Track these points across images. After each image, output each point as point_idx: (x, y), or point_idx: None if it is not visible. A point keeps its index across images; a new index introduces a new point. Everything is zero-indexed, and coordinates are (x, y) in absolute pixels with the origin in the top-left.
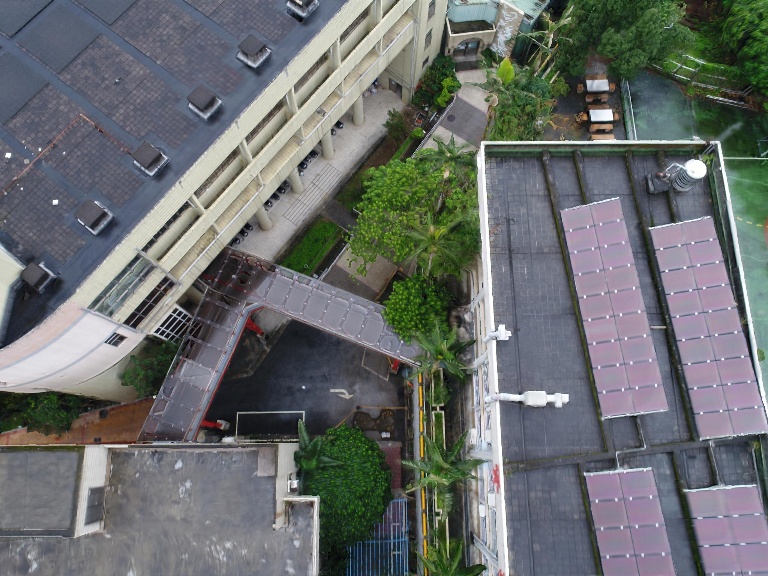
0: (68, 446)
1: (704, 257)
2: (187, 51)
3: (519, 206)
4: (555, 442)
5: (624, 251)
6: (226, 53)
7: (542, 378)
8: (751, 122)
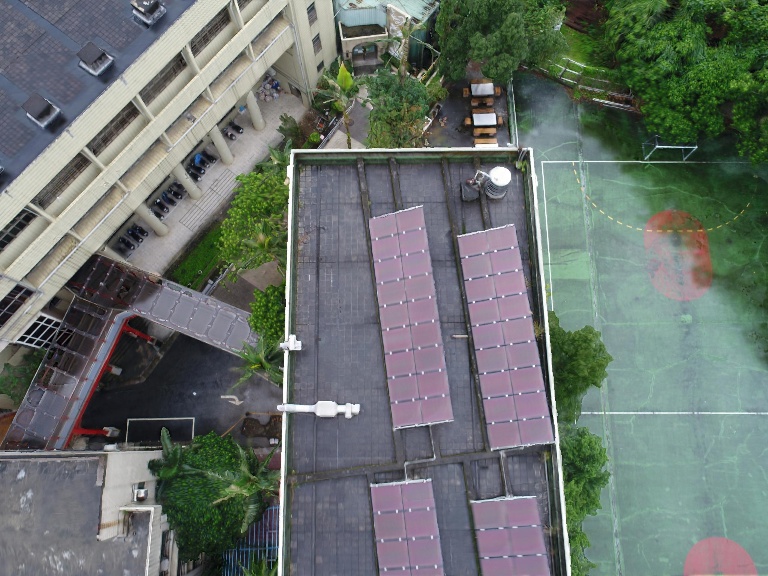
0: None
1: (505, 265)
2: (30, 59)
3: (331, 214)
4: (347, 453)
5: (423, 260)
6: (69, 61)
7: (339, 388)
8: (636, 125)
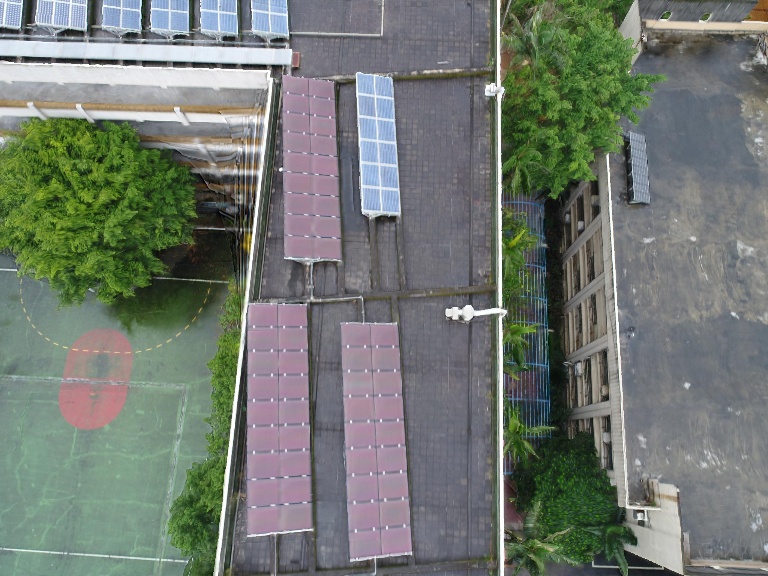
0: None
1: None
2: None
3: None
4: None
5: None
6: None
7: None
8: None
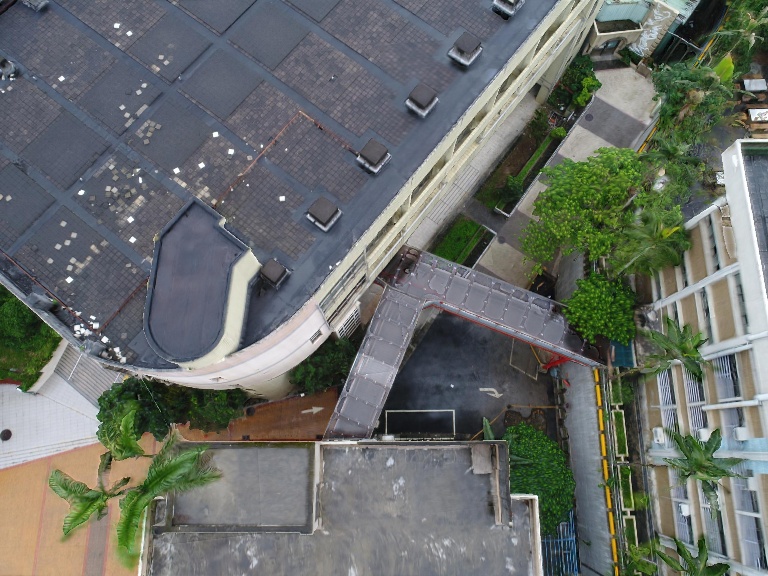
0: (298, 442)
1: None
2: (398, 48)
3: None
4: None
5: None
6: (437, 50)
7: None
8: None
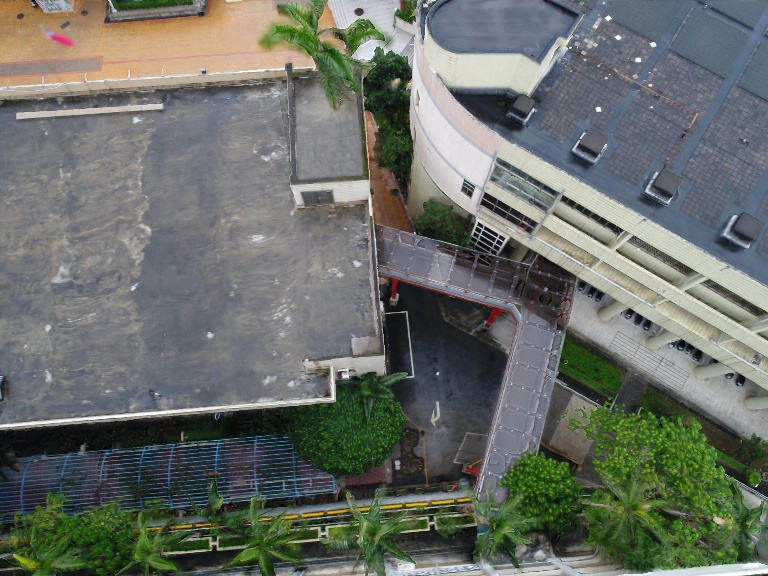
0: None
1: None
2: None
3: None
4: None
5: None
6: None
7: None
8: None
